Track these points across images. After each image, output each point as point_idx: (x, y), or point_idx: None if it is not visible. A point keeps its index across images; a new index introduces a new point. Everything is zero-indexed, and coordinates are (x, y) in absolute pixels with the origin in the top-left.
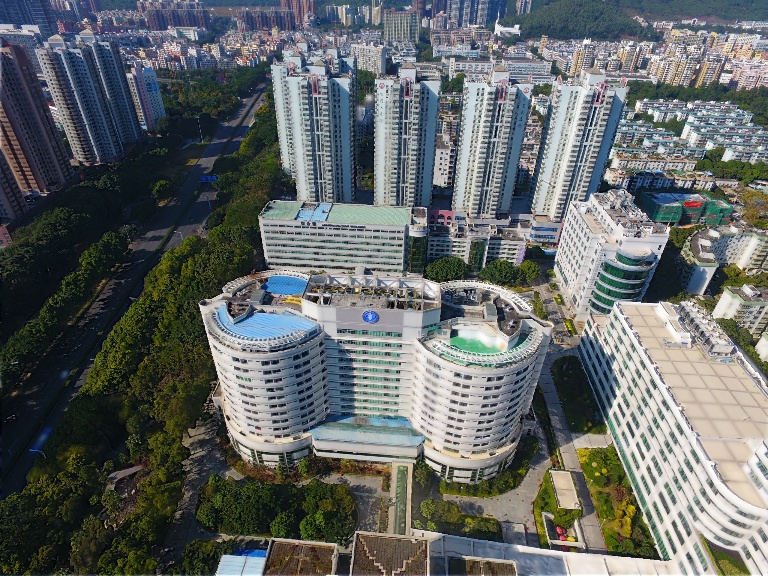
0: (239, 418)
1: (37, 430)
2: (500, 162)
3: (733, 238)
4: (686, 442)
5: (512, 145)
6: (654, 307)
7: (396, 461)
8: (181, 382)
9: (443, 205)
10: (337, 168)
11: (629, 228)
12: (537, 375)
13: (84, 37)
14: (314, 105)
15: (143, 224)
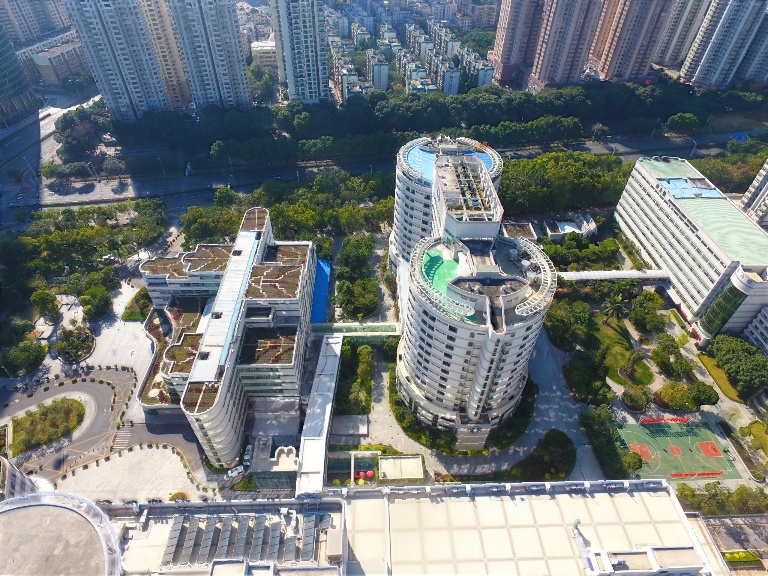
0: None
1: None
2: None
3: None
4: None
5: None
6: None
7: None
8: None
9: None
10: None
11: None
12: (479, 379)
13: None
14: None
15: (624, 136)
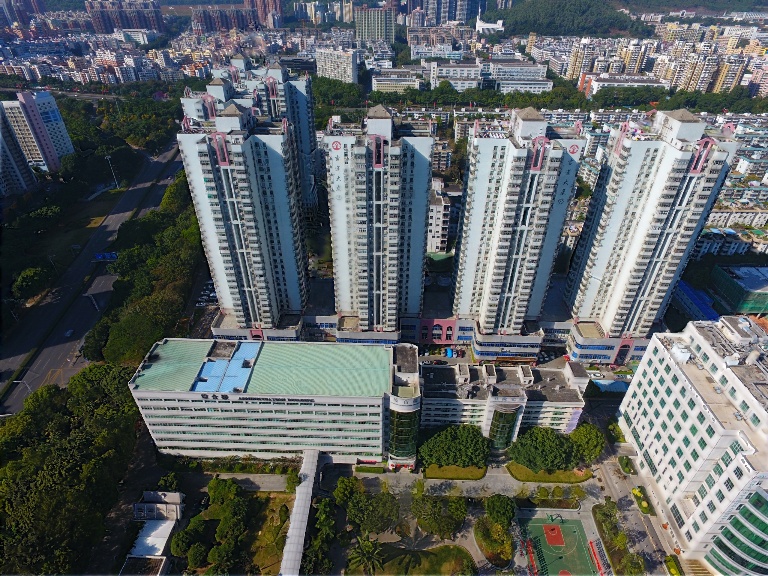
0: None
1: None
2: (531, 259)
3: None
4: None
5: (547, 229)
6: None
7: None
8: None
9: (439, 305)
10: (275, 265)
11: None
12: None
13: None
14: (224, 181)
15: None
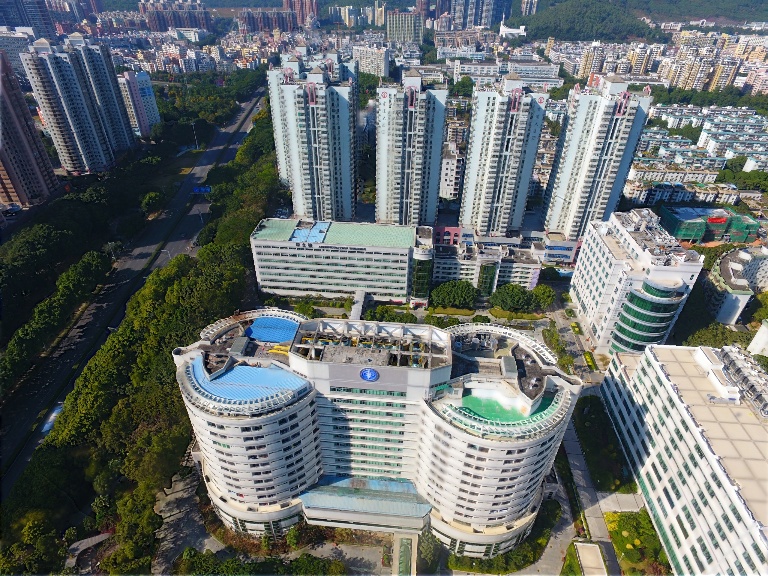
0: (218, 483)
1: None
2: (512, 177)
3: (765, 260)
4: (745, 532)
5: (525, 158)
6: (692, 351)
7: (398, 532)
8: (157, 432)
9: (449, 221)
10: (336, 182)
11: (658, 255)
12: (561, 435)
13: (73, 40)
14: (311, 116)
15: (130, 240)
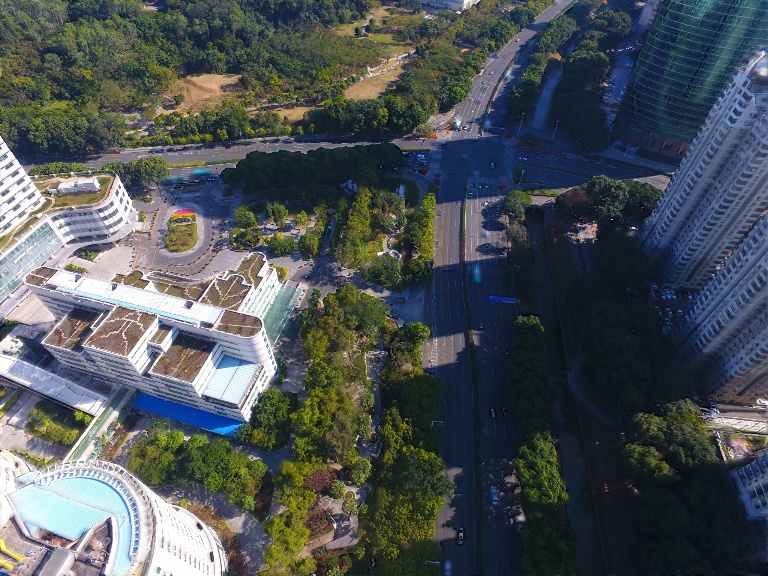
0: None
1: None
2: None
3: None
4: None
5: None
6: None
7: None
8: None
9: None
10: None
11: None
12: None
13: None
14: None
15: None
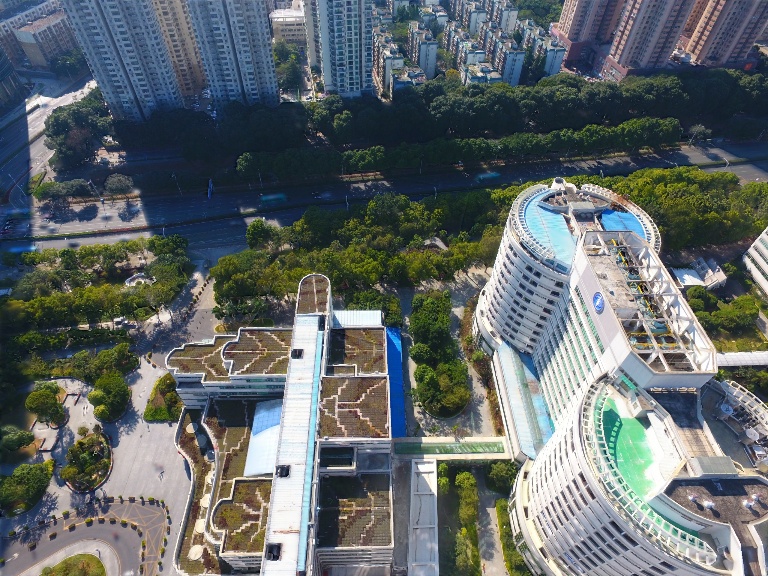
0: None
1: (461, 190)
2: None
3: None
4: None
5: None
6: None
7: (507, 439)
8: None
9: None
10: None
11: None
12: None
13: None
14: None
15: (726, 139)
